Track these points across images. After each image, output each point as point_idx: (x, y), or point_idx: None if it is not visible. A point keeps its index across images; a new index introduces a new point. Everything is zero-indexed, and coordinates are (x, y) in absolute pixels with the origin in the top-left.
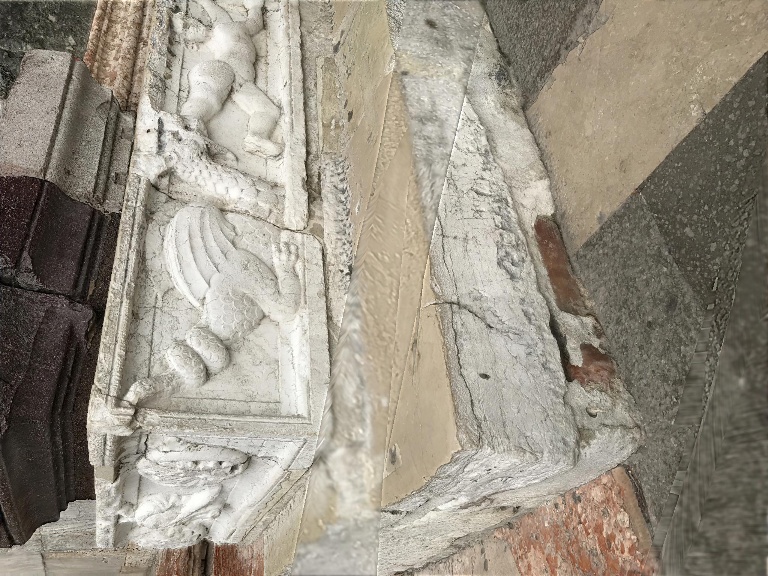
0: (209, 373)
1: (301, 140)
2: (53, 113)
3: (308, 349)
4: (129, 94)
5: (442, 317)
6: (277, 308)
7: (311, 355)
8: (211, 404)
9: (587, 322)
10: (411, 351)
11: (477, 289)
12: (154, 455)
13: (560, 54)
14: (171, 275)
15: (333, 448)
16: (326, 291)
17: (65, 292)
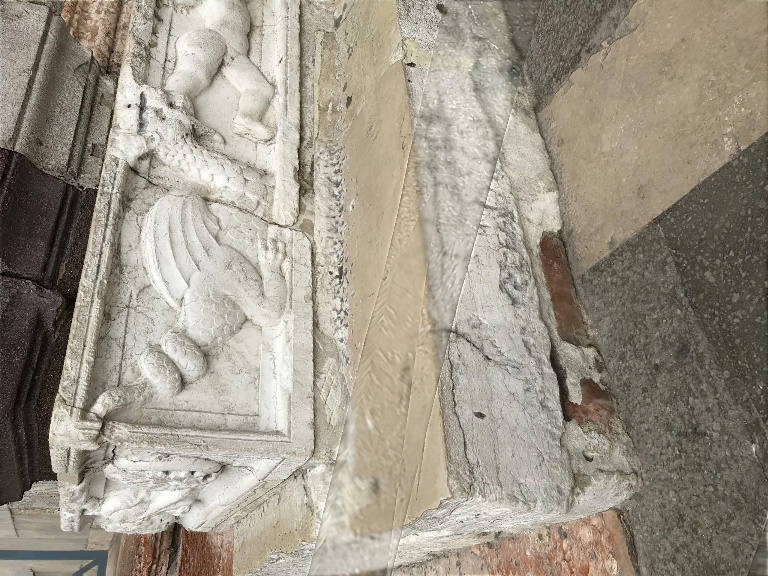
0: (184, 382)
1: (295, 125)
2: (26, 75)
3: (291, 359)
4: (111, 52)
5: None
6: (260, 312)
7: (294, 366)
8: (185, 416)
9: (589, 354)
10: None
11: (477, 315)
12: (122, 463)
13: (581, 56)
14: (148, 271)
15: None
16: (313, 295)
17: (32, 276)
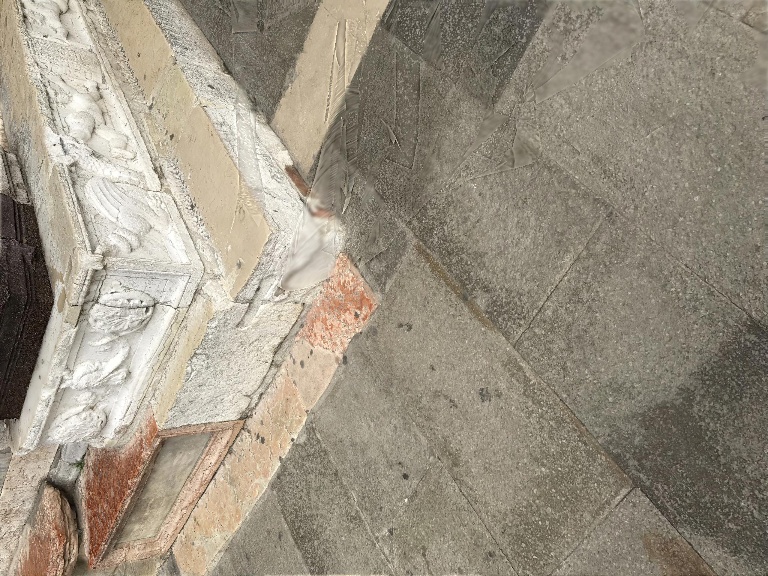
0: (131, 249)
1: (145, 150)
2: None
3: (180, 238)
4: None
5: None
6: (158, 222)
7: (183, 240)
8: None
9: None
10: (239, 213)
11: (264, 185)
12: (105, 298)
13: (282, 93)
14: (95, 208)
15: (242, 145)
16: (181, 217)
17: None
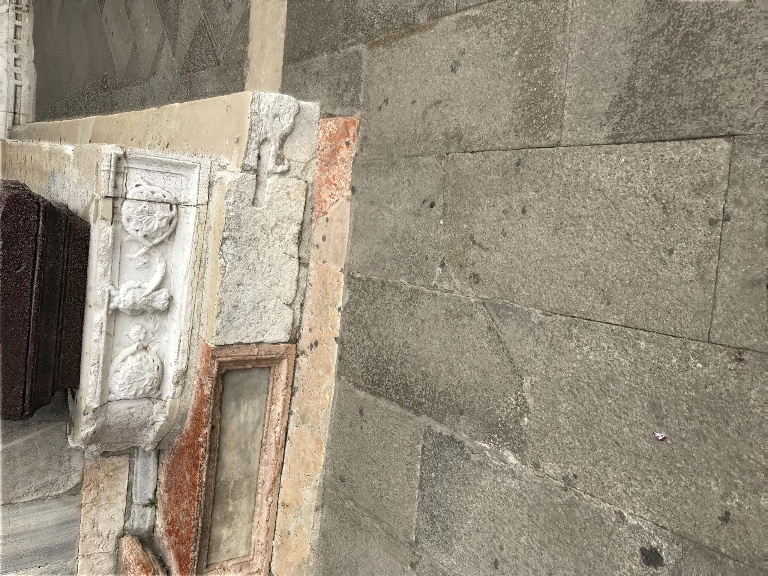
0: None
1: None
2: None
3: None
4: None
5: None
6: None
7: None
8: None
9: None
10: (227, 112)
11: None
12: (131, 191)
13: (244, 82)
14: None
15: None
16: None
17: None
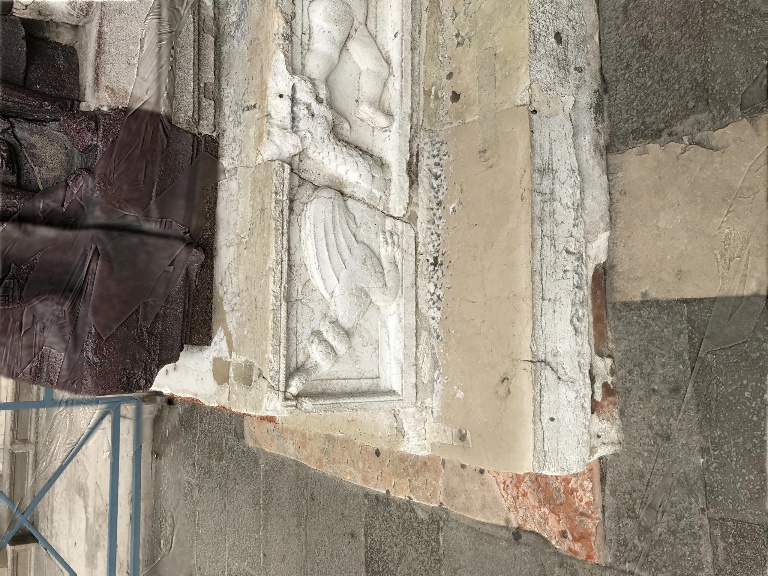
0: None
1: (408, 114)
2: None
3: (403, 336)
4: None
5: (535, 374)
6: (383, 298)
7: (405, 341)
8: (337, 384)
9: (608, 363)
10: (501, 382)
11: (556, 346)
12: None
13: (662, 135)
14: (308, 268)
15: None
16: (416, 280)
17: None
